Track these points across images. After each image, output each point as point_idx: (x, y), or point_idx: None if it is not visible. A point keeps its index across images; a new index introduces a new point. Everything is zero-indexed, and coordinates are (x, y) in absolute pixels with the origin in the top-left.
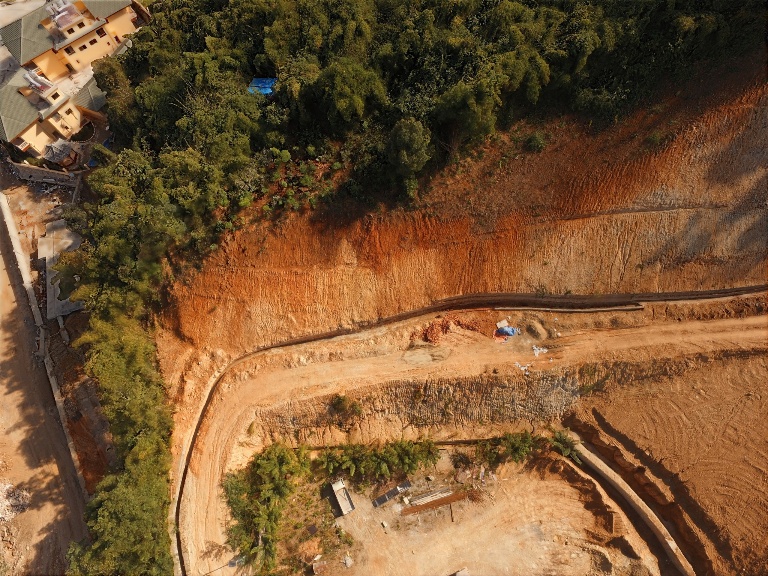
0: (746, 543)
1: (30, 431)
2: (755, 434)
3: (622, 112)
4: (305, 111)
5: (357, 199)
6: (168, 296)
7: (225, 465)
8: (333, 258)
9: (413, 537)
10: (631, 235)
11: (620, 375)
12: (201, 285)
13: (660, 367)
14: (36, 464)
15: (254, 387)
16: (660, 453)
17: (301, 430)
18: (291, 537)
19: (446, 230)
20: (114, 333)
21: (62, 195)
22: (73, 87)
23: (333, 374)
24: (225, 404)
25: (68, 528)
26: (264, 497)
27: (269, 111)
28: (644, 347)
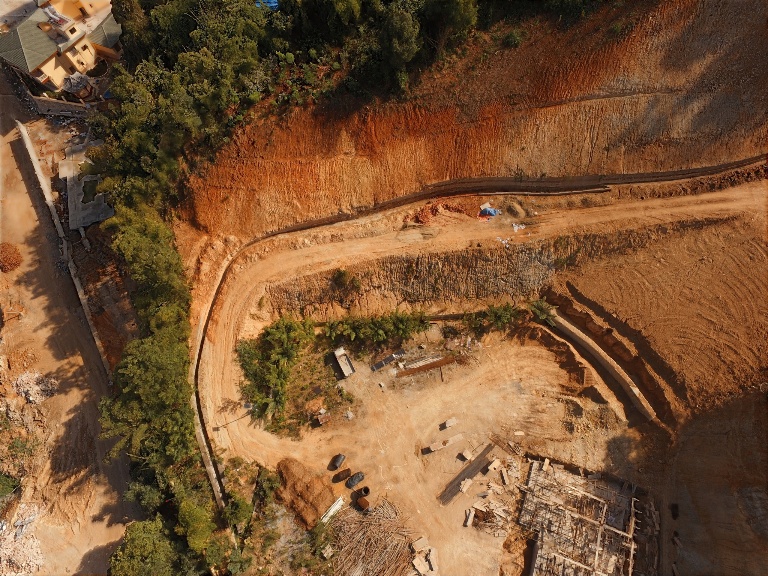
0: (699, 383)
1: (56, 329)
2: (707, 292)
3: (588, 9)
4: (307, 18)
5: (355, 93)
6: (185, 189)
7: (238, 333)
8: (333, 148)
9: (407, 394)
10: (598, 120)
11: (590, 248)
12: (215, 176)
13: (625, 239)
14: (62, 356)
15: (263, 267)
16: (625, 314)
17: (306, 307)
18: (298, 397)
19: (434, 119)
20: (137, 219)
21: (79, 126)
22: (86, 30)
23: (334, 253)
24: (238, 282)
25: (94, 408)
26: (274, 359)
27: (275, 17)
28: (611, 221)
